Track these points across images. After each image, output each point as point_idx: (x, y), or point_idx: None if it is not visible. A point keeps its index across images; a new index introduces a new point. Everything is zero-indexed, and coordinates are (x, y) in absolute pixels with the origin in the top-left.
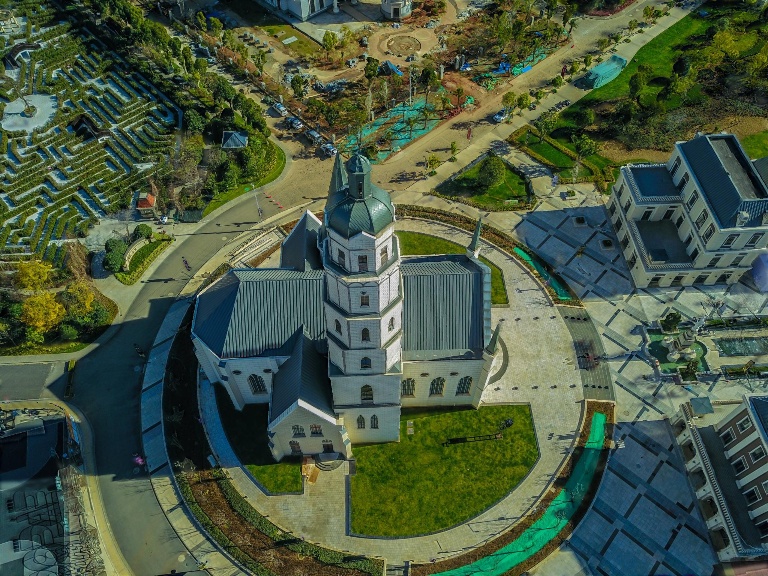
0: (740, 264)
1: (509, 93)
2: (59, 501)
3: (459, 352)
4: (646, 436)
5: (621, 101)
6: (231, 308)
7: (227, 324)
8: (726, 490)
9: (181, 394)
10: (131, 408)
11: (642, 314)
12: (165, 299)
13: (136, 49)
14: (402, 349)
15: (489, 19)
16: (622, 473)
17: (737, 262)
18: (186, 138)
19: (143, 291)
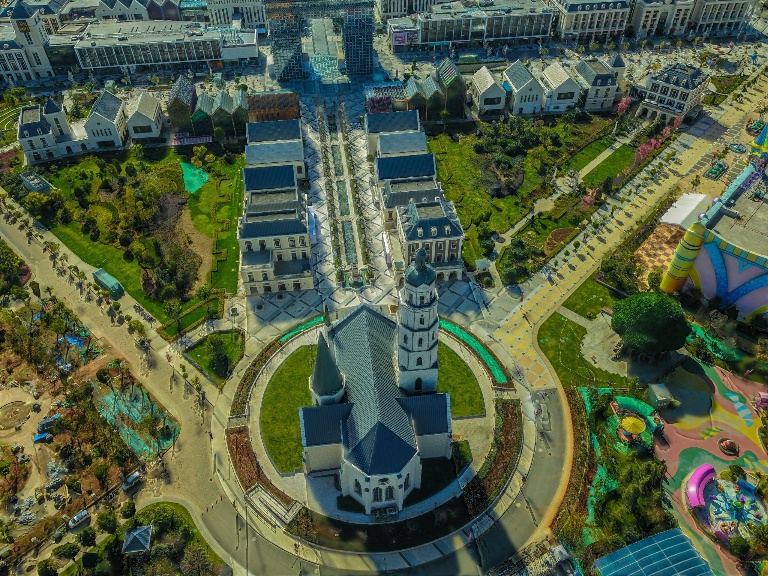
0: None
1: (140, 325)
2: None
3: None
4: None
5: (145, 277)
6: (392, 433)
7: (400, 439)
8: None
9: None
10: (425, 571)
11: (332, 289)
12: (322, 574)
13: None
14: None
15: None
16: None
17: None
18: None
19: None
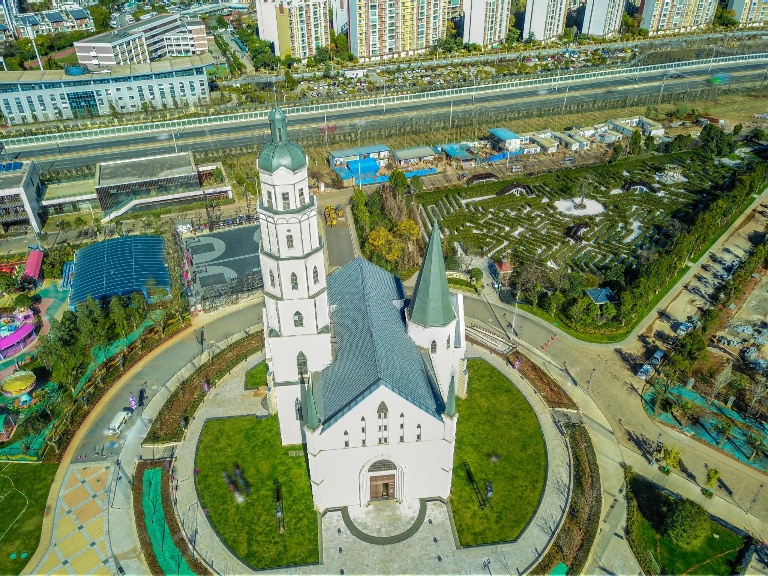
0: None
1: None
2: (259, 287)
3: (320, 413)
4: None
5: None
6: None
7: None
8: None
9: None
10: None
11: None
12: None
13: None
14: (323, 374)
15: None
16: None
17: None
18: None
19: None
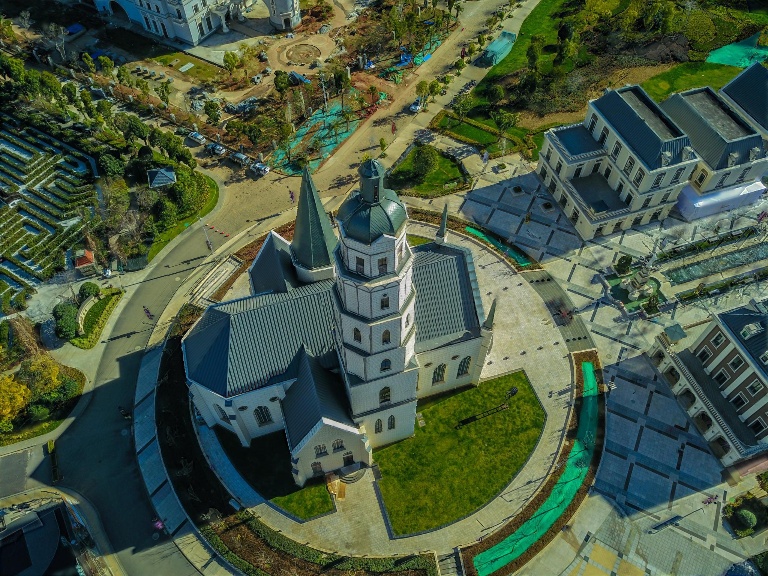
0: (668, 200)
1: (421, 82)
2: None
3: (458, 335)
4: (631, 373)
5: (521, 73)
6: (226, 344)
7: (226, 361)
8: (715, 402)
9: (181, 446)
10: (130, 474)
11: (596, 264)
12: (133, 354)
13: (22, 103)
14: None
15: (378, 16)
16: (621, 411)
17: (665, 199)
18: (107, 185)
19: (107, 351)
